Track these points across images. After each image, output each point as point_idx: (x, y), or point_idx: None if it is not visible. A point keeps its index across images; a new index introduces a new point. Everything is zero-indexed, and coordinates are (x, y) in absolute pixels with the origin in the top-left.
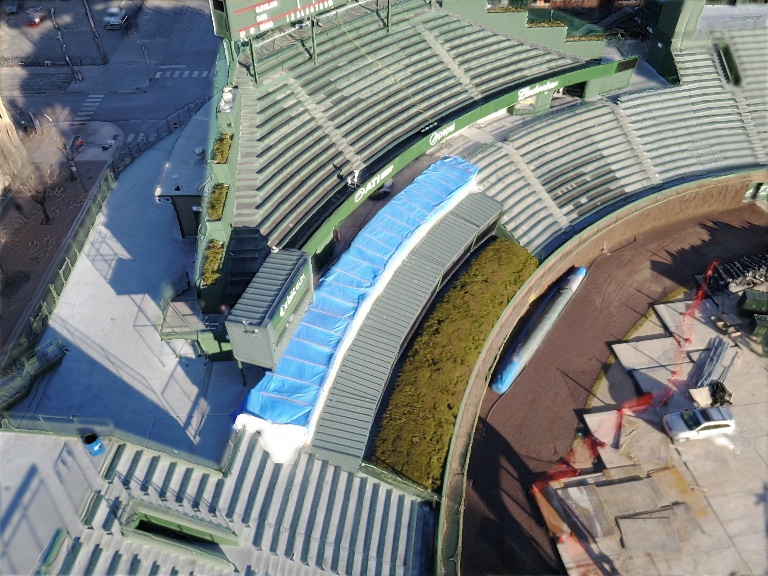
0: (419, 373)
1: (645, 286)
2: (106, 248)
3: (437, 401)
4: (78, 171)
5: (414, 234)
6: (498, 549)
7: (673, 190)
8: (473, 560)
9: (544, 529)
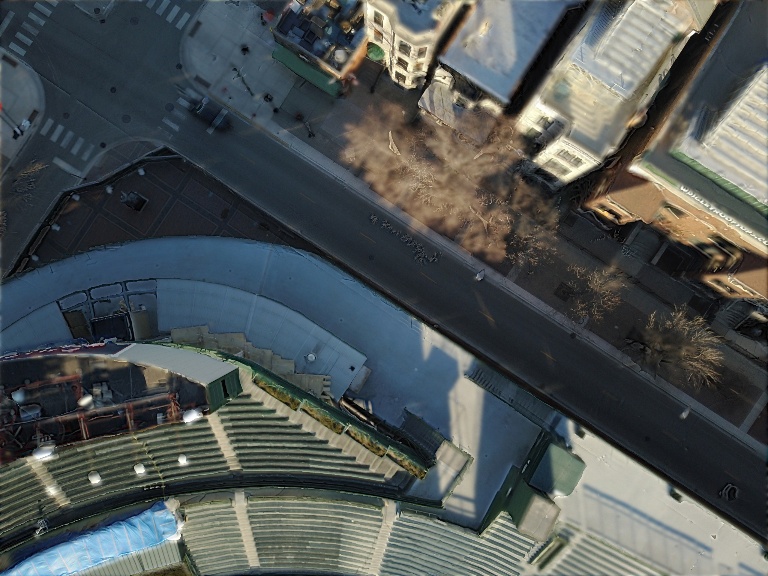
0: None
1: None
2: None
3: None
4: None
5: None
6: None
7: None
8: None
9: None
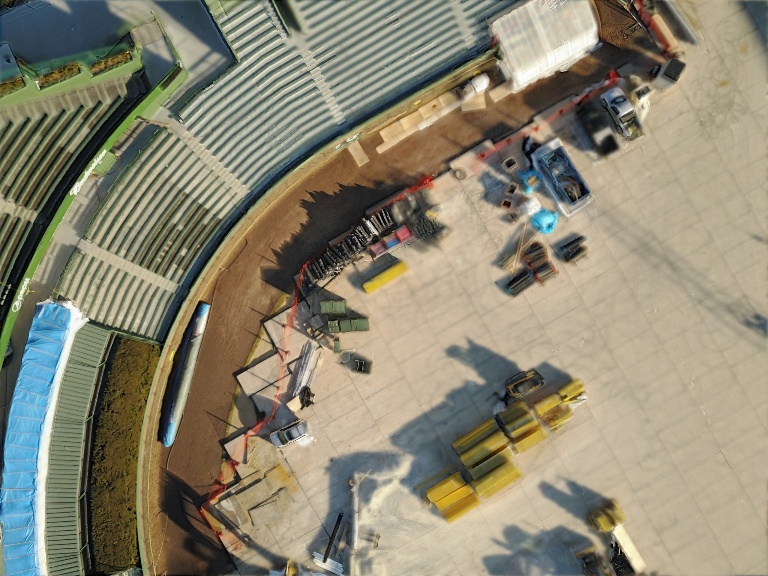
0: (102, 497)
1: (257, 302)
2: None
3: (120, 512)
4: None
5: (45, 423)
6: (191, 549)
7: (259, 202)
8: (179, 559)
9: (212, 530)
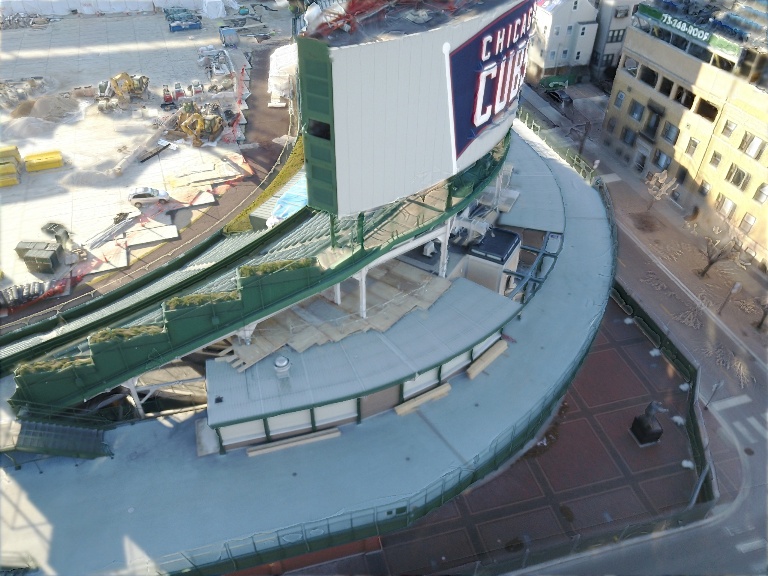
0: None
1: (123, 282)
2: (535, 149)
3: None
4: (730, 293)
5: None
6: None
7: None
8: None
9: None
